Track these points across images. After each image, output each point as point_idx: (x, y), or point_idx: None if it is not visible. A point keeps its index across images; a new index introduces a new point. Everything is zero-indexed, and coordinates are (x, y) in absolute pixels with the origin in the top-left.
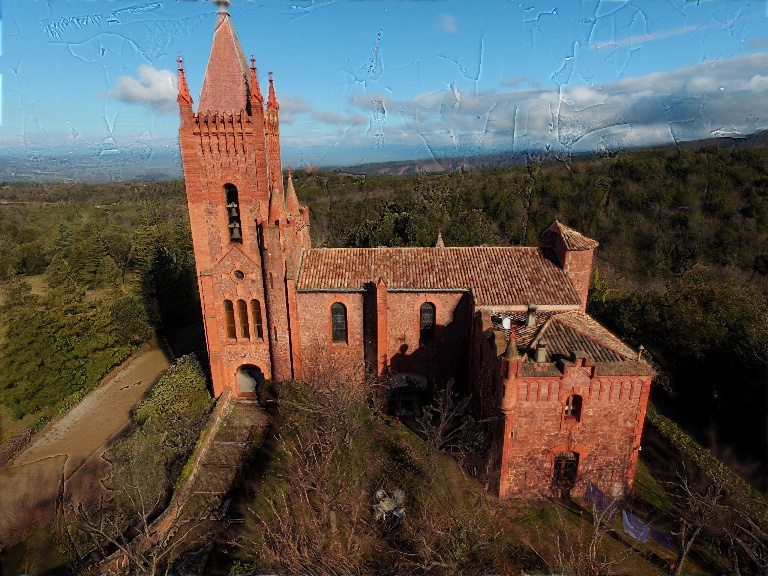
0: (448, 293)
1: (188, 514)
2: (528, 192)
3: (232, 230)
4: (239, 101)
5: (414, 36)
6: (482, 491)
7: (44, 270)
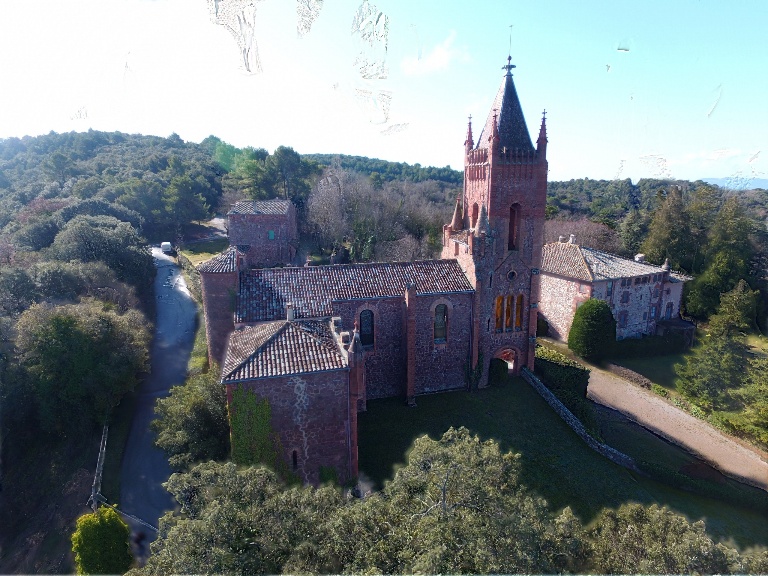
0: None
1: None
2: None
3: None
4: None
5: (357, 110)
6: None
7: None
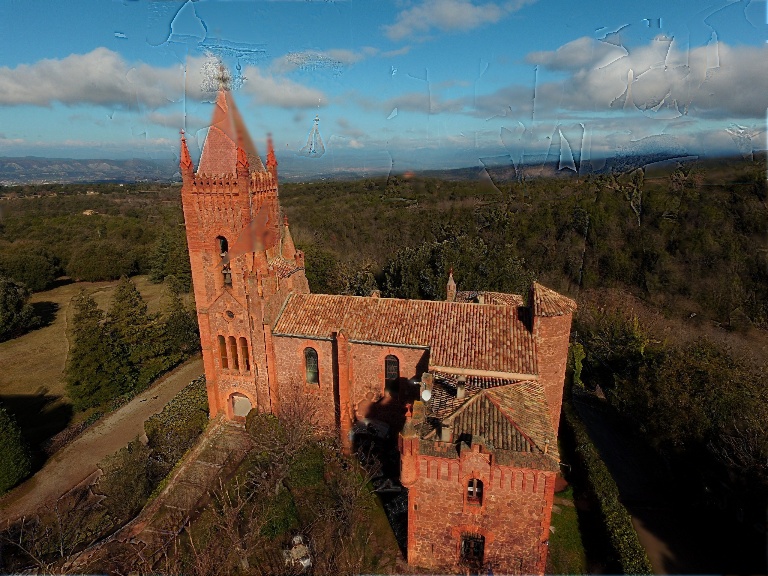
0: (410, 348)
1: (153, 525)
2: (588, 221)
3: (225, 275)
4: (231, 165)
5: (364, 113)
6: (395, 554)
7: (148, 272)
